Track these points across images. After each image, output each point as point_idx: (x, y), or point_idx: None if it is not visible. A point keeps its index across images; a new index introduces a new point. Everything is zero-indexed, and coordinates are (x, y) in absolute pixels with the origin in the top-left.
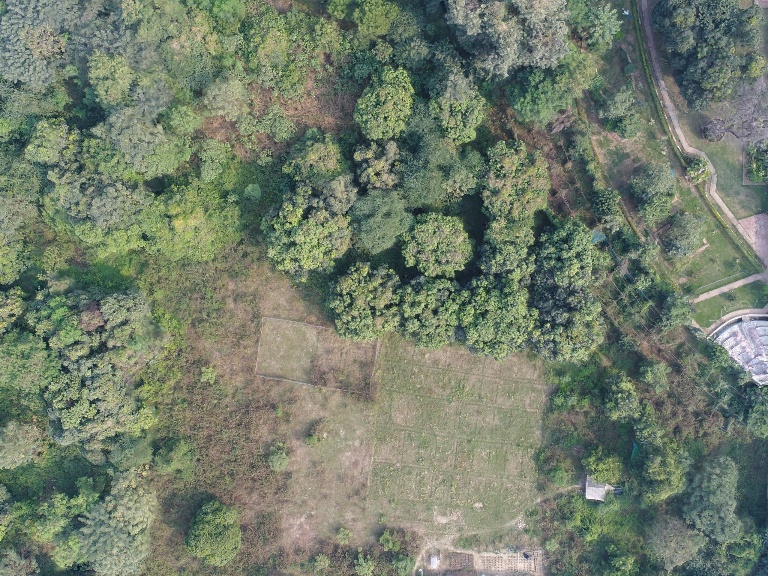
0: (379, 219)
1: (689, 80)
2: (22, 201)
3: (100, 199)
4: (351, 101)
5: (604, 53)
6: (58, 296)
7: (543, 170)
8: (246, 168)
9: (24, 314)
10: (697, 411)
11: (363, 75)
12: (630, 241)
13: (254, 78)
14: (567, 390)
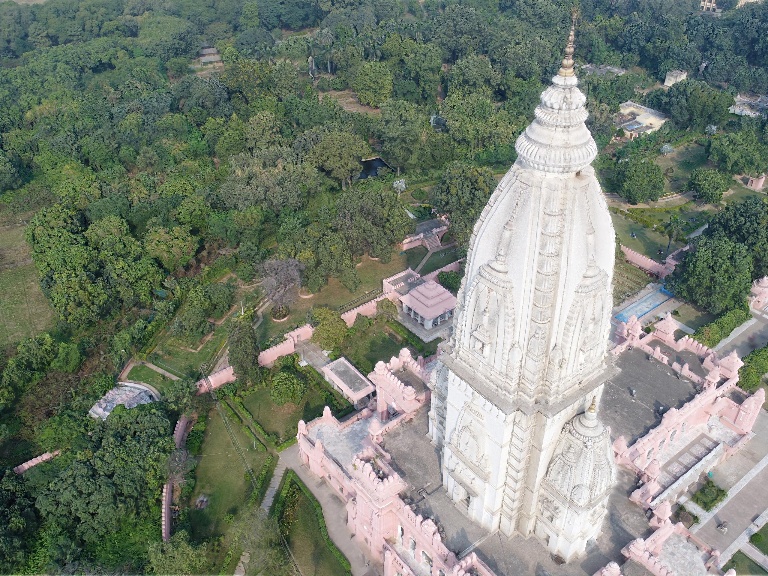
0: (107, 200)
1: None
2: None
3: None
4: None
5: None
6: None
7: (187, 250)
8: None
9: None
10: None
11: None
12: None
13: None
14: None
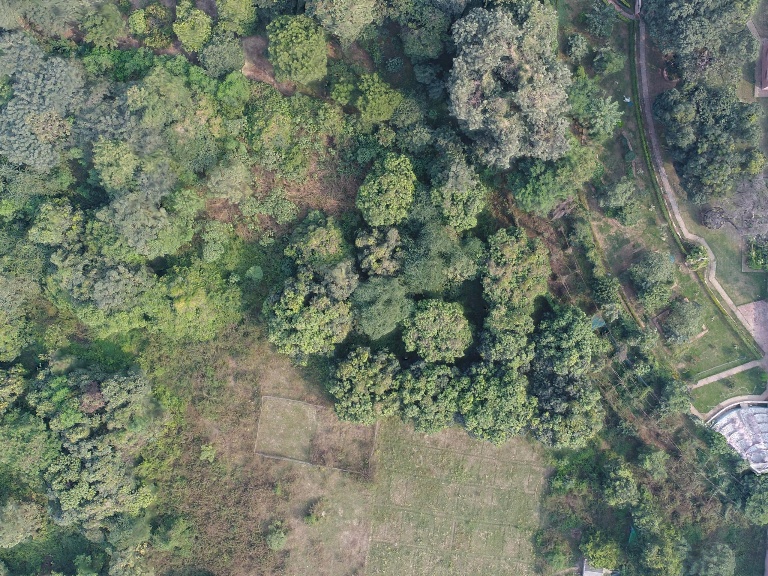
0: (380, 307)
1: (689, 174)
2: (25, 280)
3: (103, 283)
4: (353, 184)
5: (605, 139)
6: (59, 376)
7: (543, 257)
8: (248, 248)
9: (25, 394)
10: (695, 496)
11: (366, 160)
12: (629, 328)
13: (257, 160)
14: (565, 473)
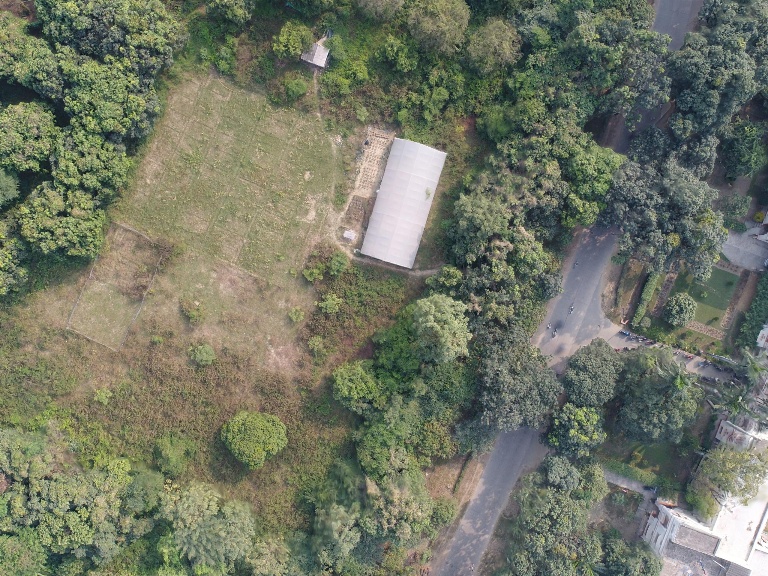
0: None
1: None
2: None
3: None
4: None
5: None
6: None
7: None
8: None
9: None
10: None
11: None
12: None
13: None
14: None
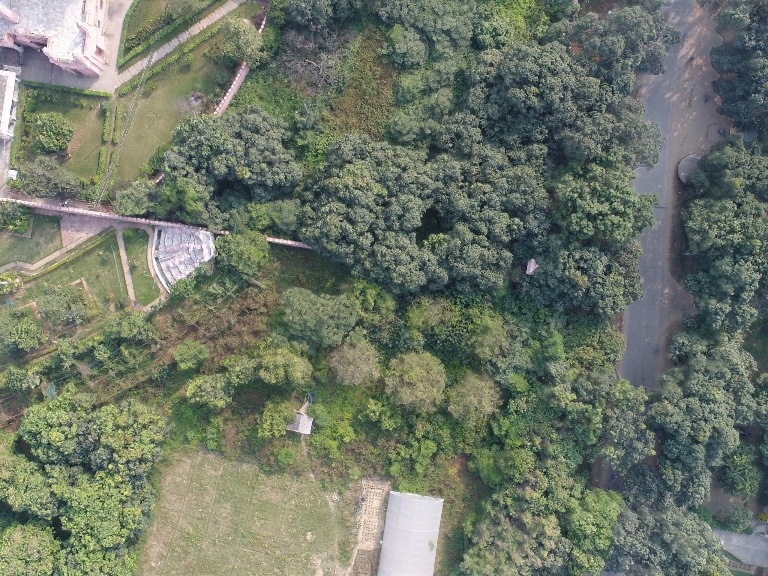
0: None
1: None
2: None
3: None
4: None
5: None
6: None
7: None
8: None
9: None
10: (240, 312)
11: None
12: (57, 362)
13: None
14: None
